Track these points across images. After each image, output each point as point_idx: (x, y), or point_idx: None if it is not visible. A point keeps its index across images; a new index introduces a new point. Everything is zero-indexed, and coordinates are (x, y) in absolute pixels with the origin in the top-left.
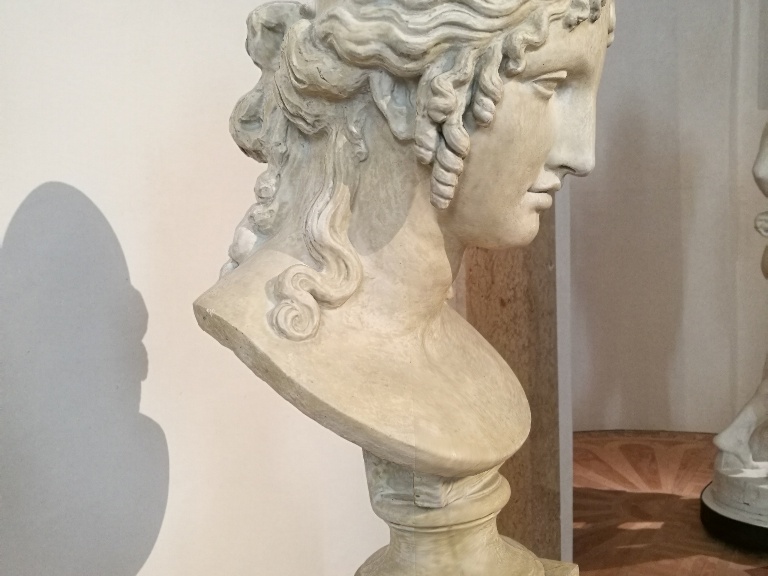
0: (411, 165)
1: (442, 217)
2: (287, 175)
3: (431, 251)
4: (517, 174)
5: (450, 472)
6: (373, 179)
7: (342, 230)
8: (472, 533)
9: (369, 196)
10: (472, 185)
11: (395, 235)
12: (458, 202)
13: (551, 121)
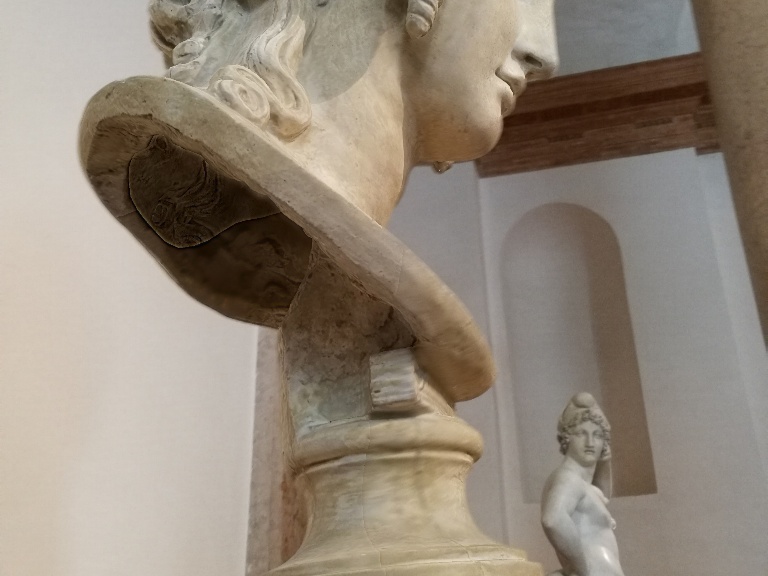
0: (378, 12)
1: (407, 77)
2: (219, 37)
3: (390, 120)
4: (491, 36)
5: (437, 320)
6: (332, 24)
7: (291, 68)
8: (445, 475)
9: (326, 41)
10: (446, 36)
11: (353, 84)
12: (428, 56)
13: (518, 8)
